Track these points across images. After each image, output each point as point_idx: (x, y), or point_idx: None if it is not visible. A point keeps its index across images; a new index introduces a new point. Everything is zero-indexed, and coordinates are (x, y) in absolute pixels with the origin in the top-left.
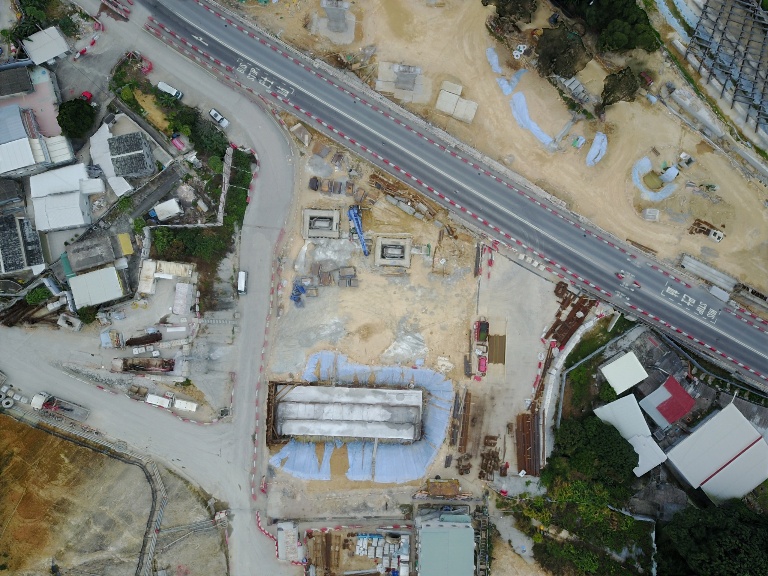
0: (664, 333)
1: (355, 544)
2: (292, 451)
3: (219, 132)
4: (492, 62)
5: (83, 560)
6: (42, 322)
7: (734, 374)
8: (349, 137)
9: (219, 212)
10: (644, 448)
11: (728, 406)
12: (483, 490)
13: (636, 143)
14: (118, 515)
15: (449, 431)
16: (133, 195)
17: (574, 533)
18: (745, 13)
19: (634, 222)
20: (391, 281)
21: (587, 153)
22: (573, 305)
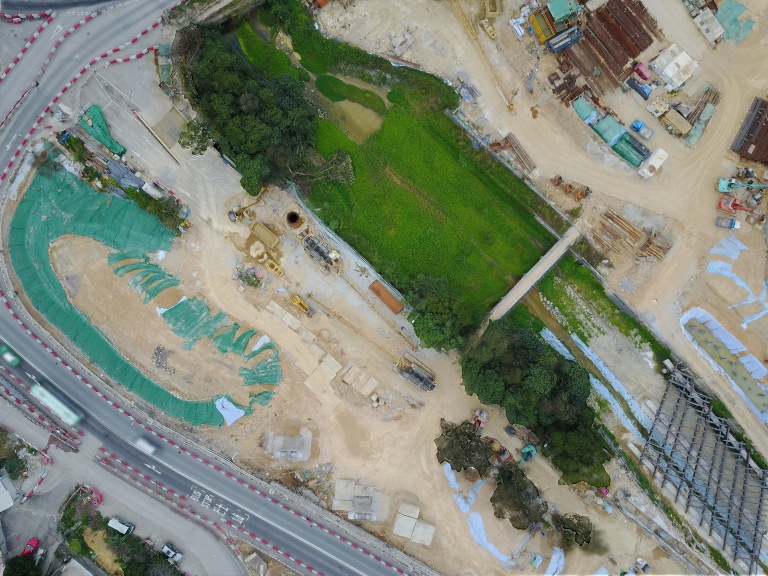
0: None
1: None
2: None
3: (172, 565)
4: (449, 478)
5: None
6: None
7: None
8: (305, 564)
9: None
10: None
11: None
12: None
13: (593, 553)
14: None
15: None
16: None
17: None
18: (697, 417)
19: None
20: None
21: (545, 571)
22: None
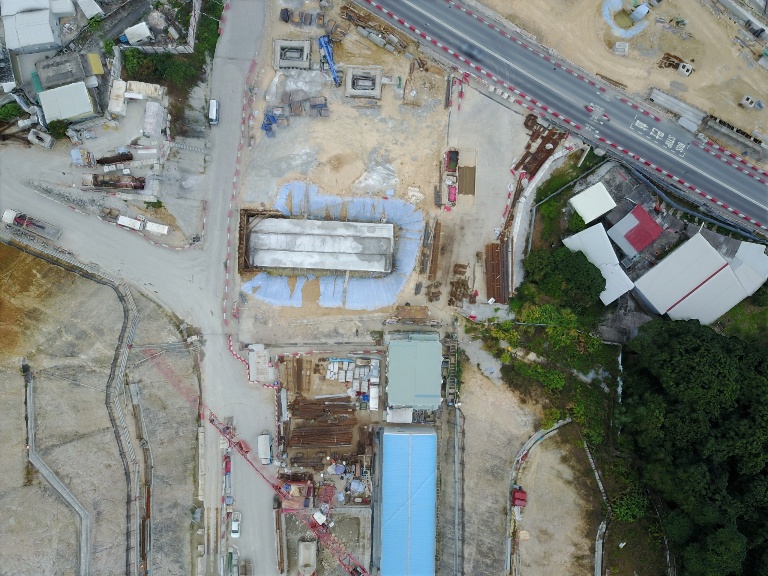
0: (633, 166)
1: (326, 369)
2: (264, 281)
3: None
4: None
5: (54, 363)
6: (13, 139)
7: (702, 207)
8: None
9: (189, 34)
10: (612, 276)
11: (695, 236)
12: (452, 317)
13: None
14: (89, 328)
15: (419, 259)
16: (104, 20)
17: (541, 355)
18: None
19: (604, 57)
20: (362, 113)
21: None
22: (543, 137)
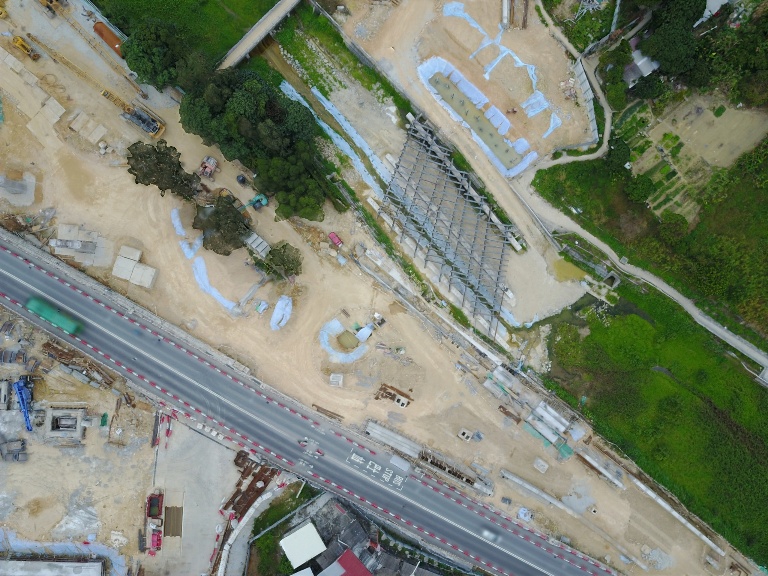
0: None
1: None
2: None
3: None
4: (175, 224)
5: None
6: None
7: (420, 542)
8: (22, 304)
9: None
10: None
11: None
12: None
13: (326, 305)
14: None
15: None
16: None
17: None
18: (438, 172)
19: (321, 387)
20: (65, 452)
21: (270, 318)
22: (254, 474)
